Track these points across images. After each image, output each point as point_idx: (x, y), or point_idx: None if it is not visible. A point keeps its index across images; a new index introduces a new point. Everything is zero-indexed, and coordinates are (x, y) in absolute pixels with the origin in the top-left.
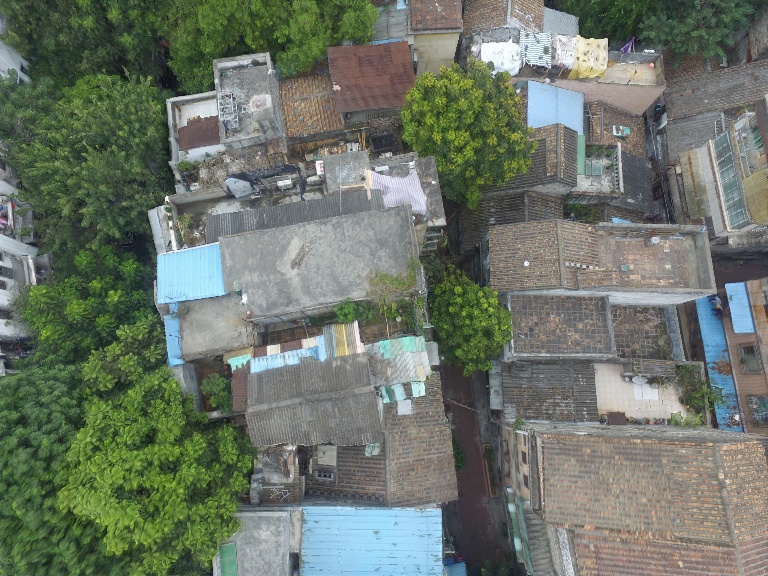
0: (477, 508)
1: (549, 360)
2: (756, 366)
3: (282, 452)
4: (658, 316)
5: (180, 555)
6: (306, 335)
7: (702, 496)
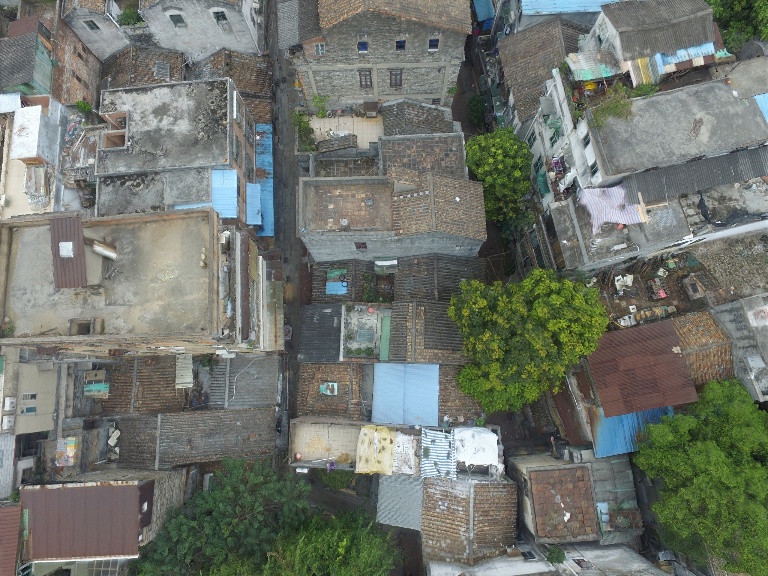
0: None
1: None
2: None
3: None
4: None
5: None
6: None
7: None
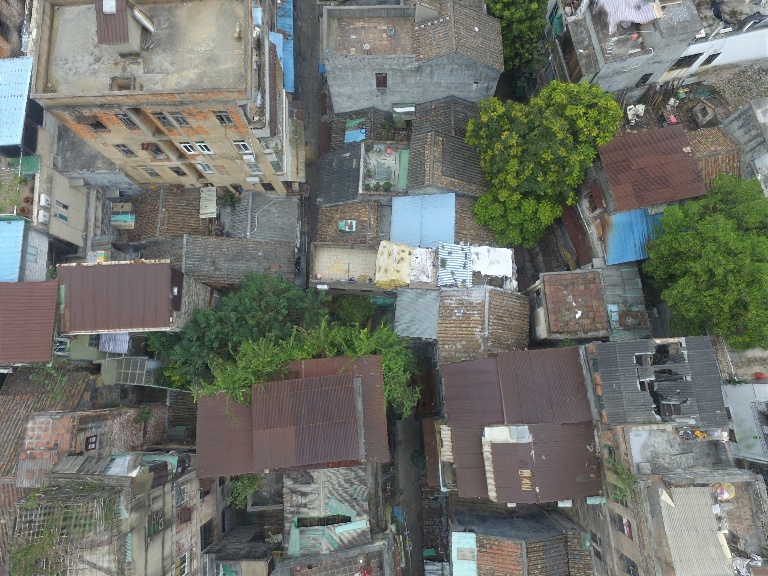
0: None
1: None
2: None
3: None
4: None
5: None
6: None
7: None
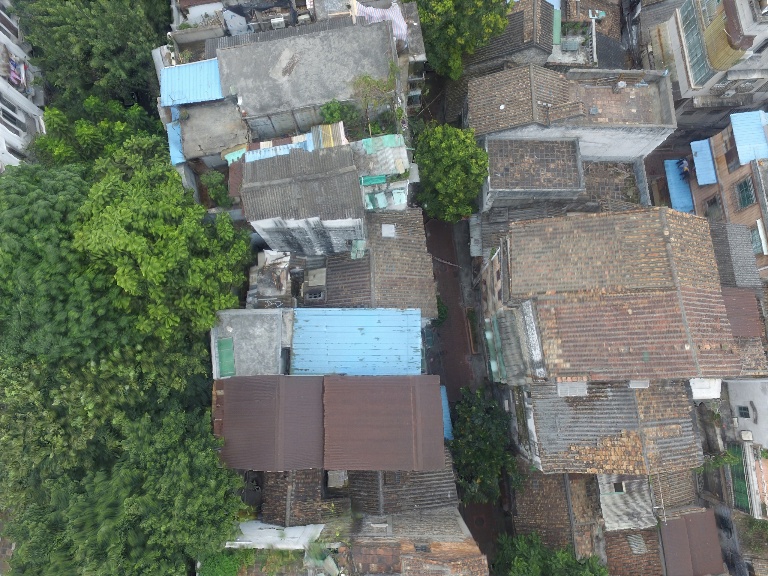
0: (460, 365)
1: (524, 204)
2: (718, 213)
3: (275, 269)
4: (627, 170)
5: (182, 345)
6: (296, 133)
7: (649, 252)
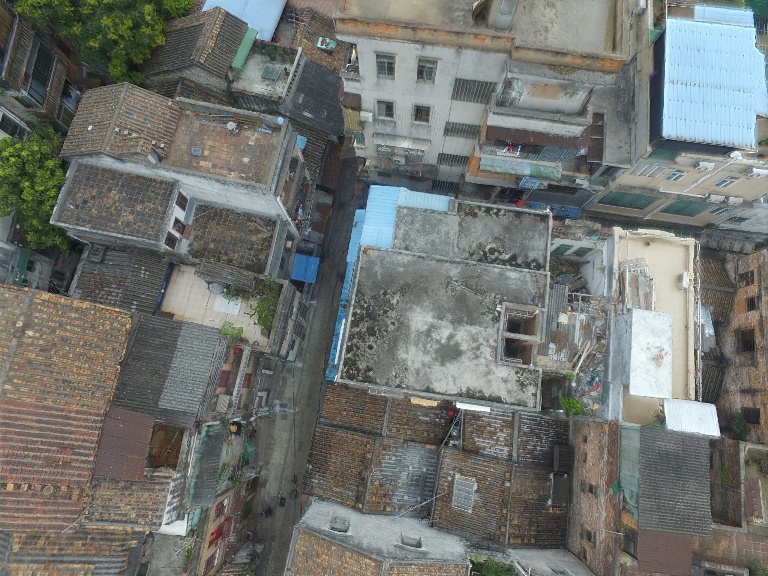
0: None
1: (121, 247)
2: None
3: None
4: (268, 228)
5: None
6: None
7: None
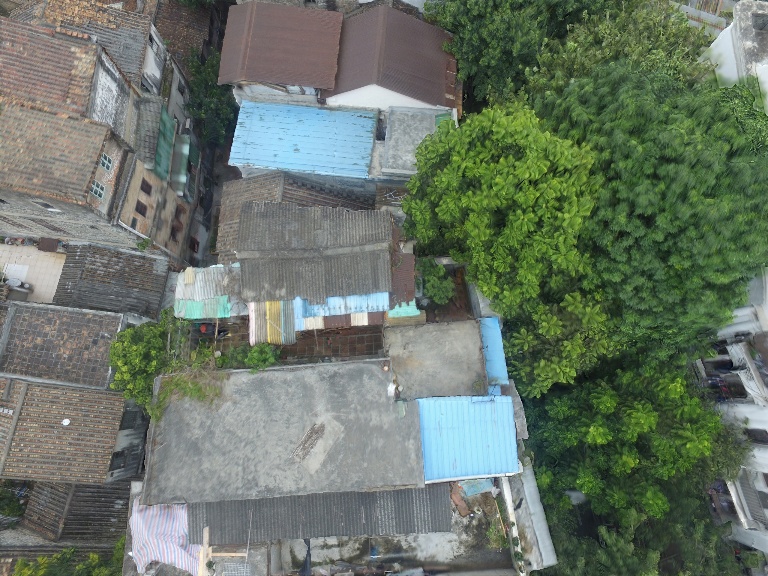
0: None
1: None
2: None
3: None
4: None
5: None
6: None
7: None
